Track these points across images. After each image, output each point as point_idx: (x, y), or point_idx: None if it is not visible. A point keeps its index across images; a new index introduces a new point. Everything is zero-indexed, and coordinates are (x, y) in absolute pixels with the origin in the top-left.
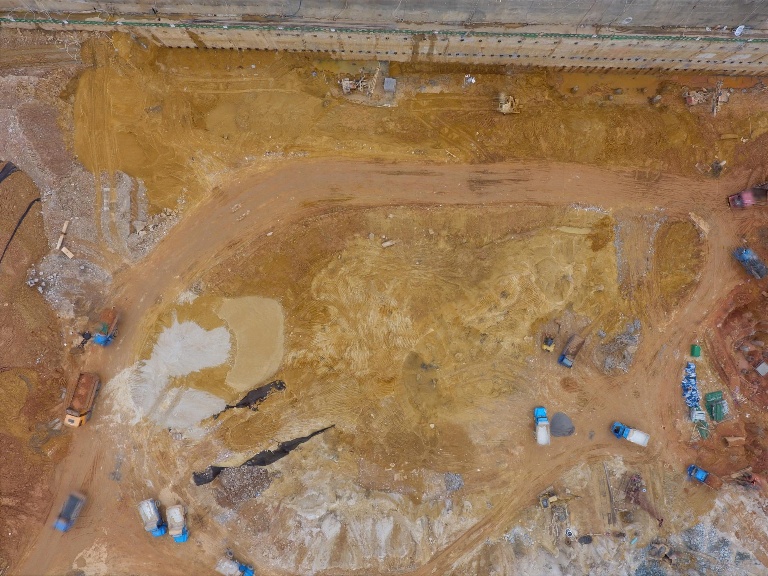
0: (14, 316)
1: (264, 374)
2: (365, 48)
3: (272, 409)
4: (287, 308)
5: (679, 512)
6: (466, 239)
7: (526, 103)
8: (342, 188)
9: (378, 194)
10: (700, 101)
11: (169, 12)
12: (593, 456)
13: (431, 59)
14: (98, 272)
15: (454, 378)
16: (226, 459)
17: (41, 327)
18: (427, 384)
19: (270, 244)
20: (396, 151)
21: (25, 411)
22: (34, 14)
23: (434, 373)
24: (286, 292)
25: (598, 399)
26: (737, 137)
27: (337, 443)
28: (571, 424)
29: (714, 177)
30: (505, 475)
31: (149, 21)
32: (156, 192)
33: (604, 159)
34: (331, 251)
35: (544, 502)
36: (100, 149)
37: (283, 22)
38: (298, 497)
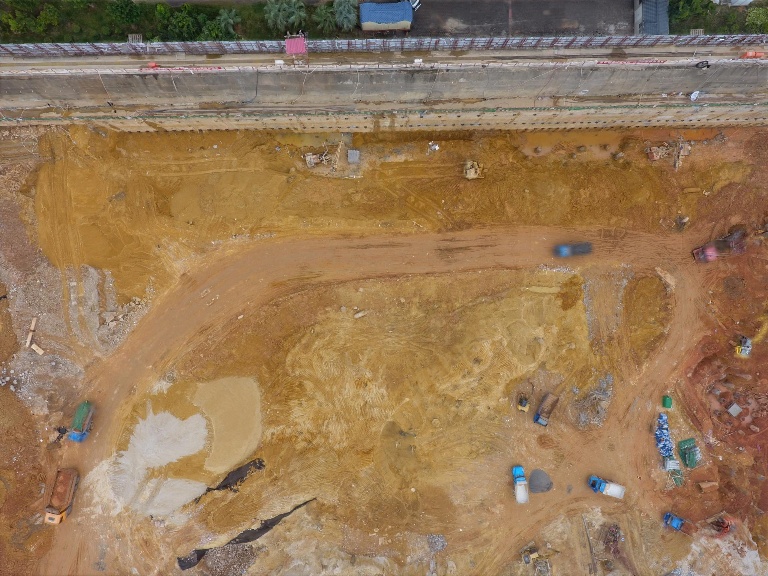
0: None
1: (243, 453)
2: (326, 125)
3: (253, 489)
4: (263, 385)
5: (657, 558)
6: (438, 304)
7: (490, 167)
8: (311, 266)
9: (347, 269)
10: (662, 156)
11: (125, 104)
12: (572, 509)
13: (393, 129)
14: (70, 367)
15: (432, 444)
16: (210, 542)
17: (15, 426)
18: (406, 449)
19: (241, 327)
20: (363, 225)
21: (5, 510)
22: None
23: (412, 440)
24: (261, 369)
25: (574, 454)
26: (699, 190)
27: (320, 514)
28: (549, 480)
29: (678, 232)
30: (487, 533)
31: (105, 113)
32: (124, 281)
33: (569, 220)
34: (304, 326)
35: (526, 559)
36: (64, 244)
37: (241, 108)
38: (284, 569)
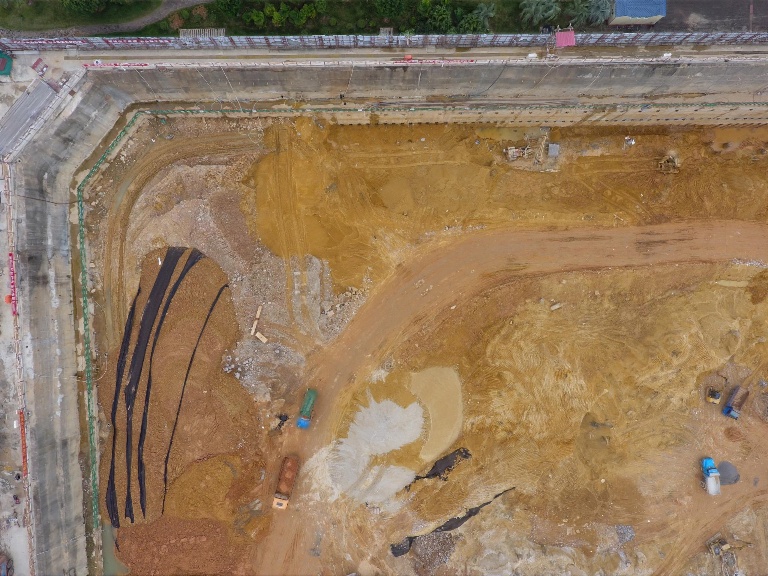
0: (215, 403)
1: (448, 443)
2: (536, 119)
3: (460, 477)
4: (463, 375)
5: None
6: (629, 297)
7: (684, 162)
8: (518, 258)
9: (551, 261)
10: None
11: (355, 96)
12: (758, 502)
13: (593, 124)
14: (292, 355)
15: (627, 435)
16: (421, 529)
17: (241, 412)
18: (596, 440)
19: (453, 317)
20: (567, 218)
21: (230, 495)
22: (221, 104)
23: (607, 431)
24: (461, 360)
25: (761, 447)
26: None
27: (515, 503)
28: (736, 472)
29: None
30: (674, 524)
31: (335, 106)
32: (340, 271)
33: (764, 215)
34: (503, 317)
35: (716, 550)
36: (289, 234)
37: (467, 101)
38: (479, 557)
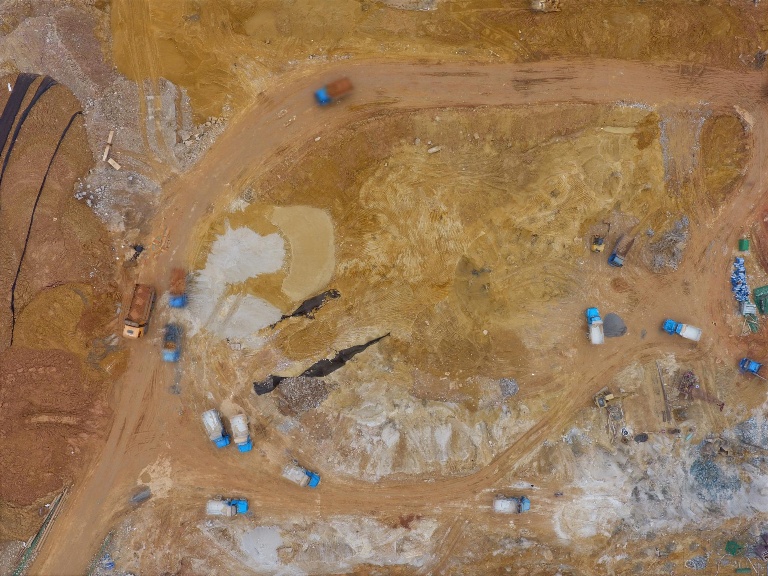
0: (64, 230)
1: (317, 284)
2: None
3: (328, 317)
4: (336, 218)
5: (732, 406)
6: (511, 143)
7: (566, 1)
8: (387, 91)
9: (423, 96)
10: None
11: None
12: (646, 355)
13: None
14: (147, 183)
15: (506, 282)
16: (286, 368)
17: (92, 240)
18: (478, 291)
19: (318, 149)
20: (440, 51)
21: (82, 326)
22: None
23: (486, 278)
24: (334, 202)
25: (649, 298)
26: None
27: (392, 353)
28: (623, 324)
29: (757, 68)
30: (559, 378)
31: None
32: (200, 101)
33: (648, 54)
34: (377, 159)
35: (600, 401)
36: (141, 56)
37: None
38: (356, 408)
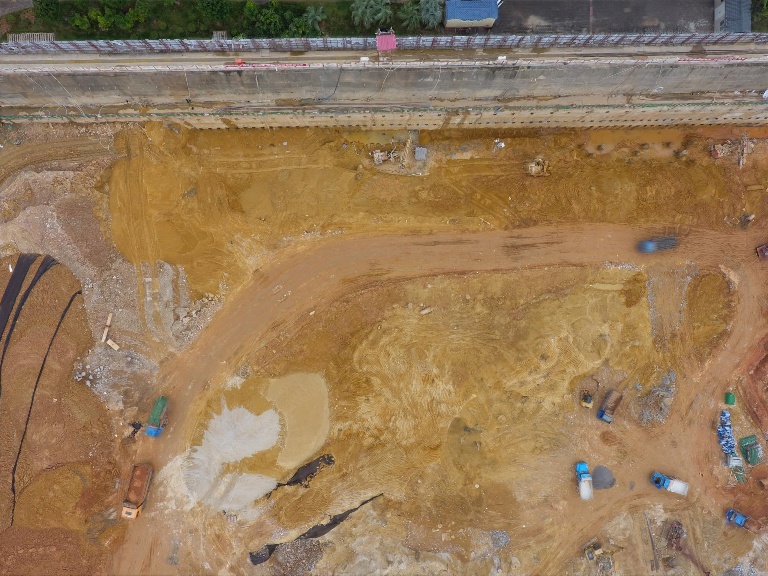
0: (64, 412)
1: (312, 449)
2: (397, 122)
3: (323, 484)
4: (330, 381)
5: (719, 555)
6: (502, 301)
7: (555, 164)
8: (380, 262)
9: (416, 265)
10: (725, 154)
11: (202, 101)
12: (634, 506)
13: (460, 126)
14: (145, 362)
15: (497, 440)
16: (281, 537)
17: (91, 421)
18: (470, 446)
19: (313, 323)
20: (431, 222)
21: (81, 505)
22: (66, 109)
23: (478, 436)
24: (328, 365)
25: (637, 451)
26: (763, 188)
27: (386, 510)
28: (612, 476)
29: (742, 229)
30: (550, 529)
31: (182, 110)
32: (197, 277)
33: (635, 217)
34: (371, 322)
35: (590, 555)
36: (139, 240)
37: (317, 105)
38: (350, 564)
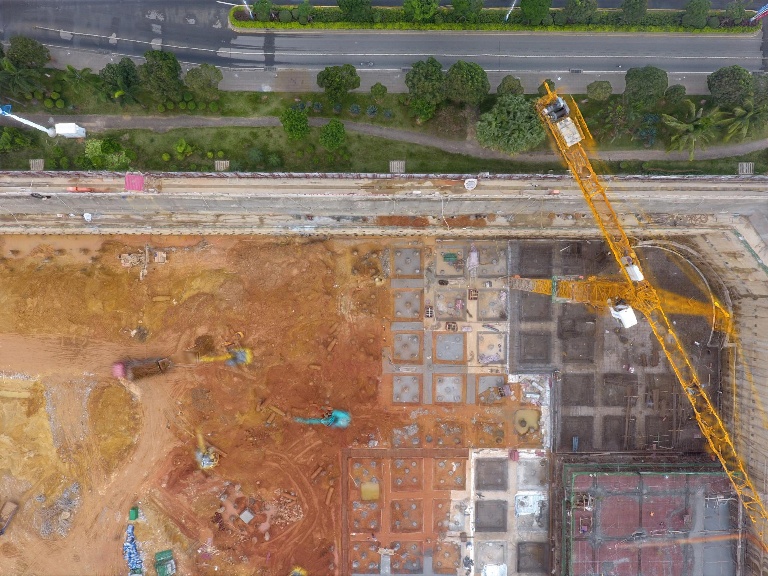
0: None
1: None
2: None
3: None
4: None
5: None
6: None
7: None
8: None
9: None
10: (133, 263)
11: None
12: None
13: None
14: None
15: None
16: None
17: None
18: None
19: None
20: None
21: None
22: None
23: None
24: None
25: (38, 564)
26: (169, 299)
27: None
28: None
29: (141, 341)
30: None
31: None
32: None
33: (24, 328)
34: None
35: None
36: None
37: None
38: None
